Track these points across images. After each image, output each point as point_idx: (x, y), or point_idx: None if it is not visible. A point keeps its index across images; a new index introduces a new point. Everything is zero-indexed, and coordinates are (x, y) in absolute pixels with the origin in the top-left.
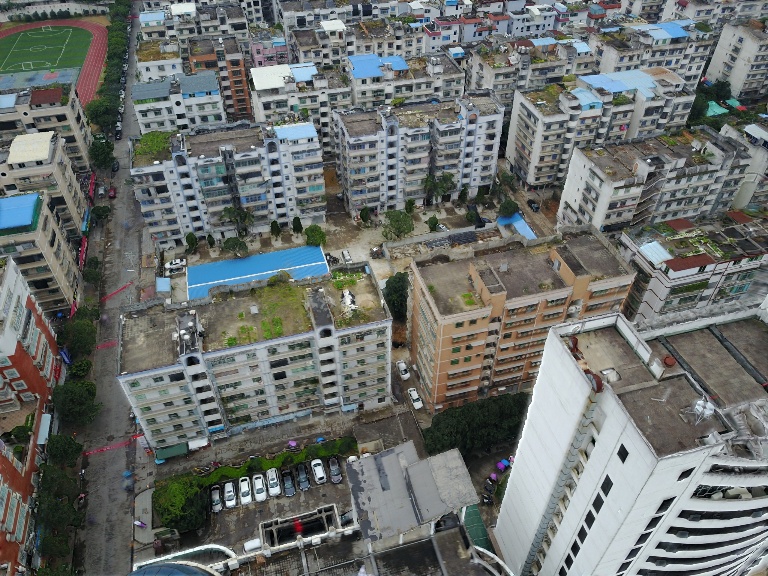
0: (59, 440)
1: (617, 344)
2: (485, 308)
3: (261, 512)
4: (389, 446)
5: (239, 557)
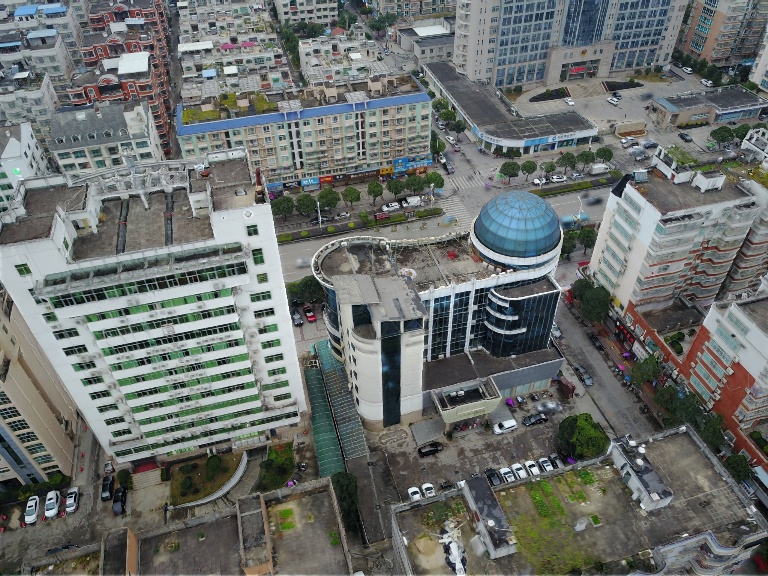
0: (735, 459)
1: (223, 209)
2: (271, 492)
3: (512, 456)
4: (395, 500)
5: (491, 278)
